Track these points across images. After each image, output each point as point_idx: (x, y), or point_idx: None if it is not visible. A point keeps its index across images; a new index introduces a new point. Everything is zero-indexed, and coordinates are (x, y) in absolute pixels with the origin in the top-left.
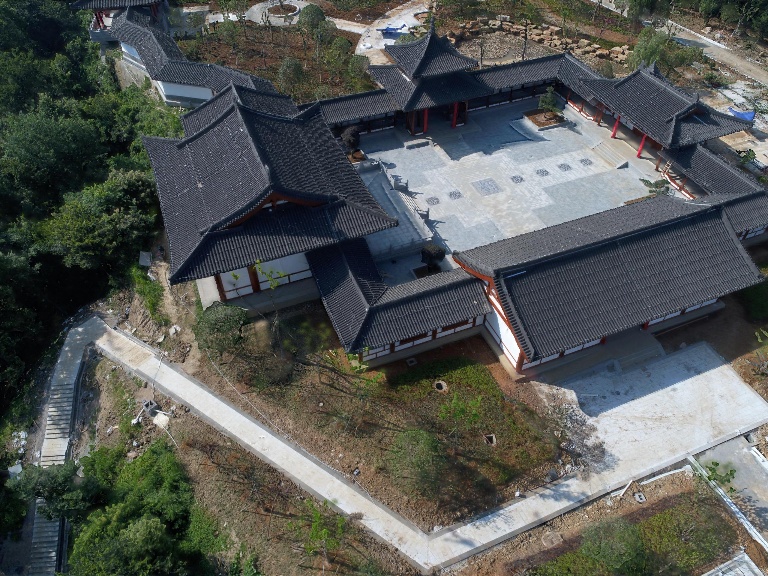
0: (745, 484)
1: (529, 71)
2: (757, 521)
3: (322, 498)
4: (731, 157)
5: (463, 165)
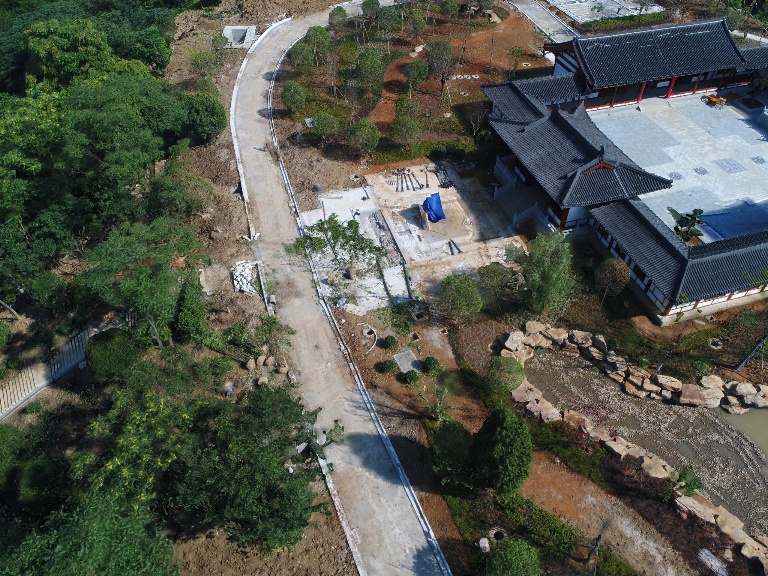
0: (567, 38)
1: (737, 246)
2: (567, 31)
3: (759, 36)
4: (466, 187)
5: (765, 189)
